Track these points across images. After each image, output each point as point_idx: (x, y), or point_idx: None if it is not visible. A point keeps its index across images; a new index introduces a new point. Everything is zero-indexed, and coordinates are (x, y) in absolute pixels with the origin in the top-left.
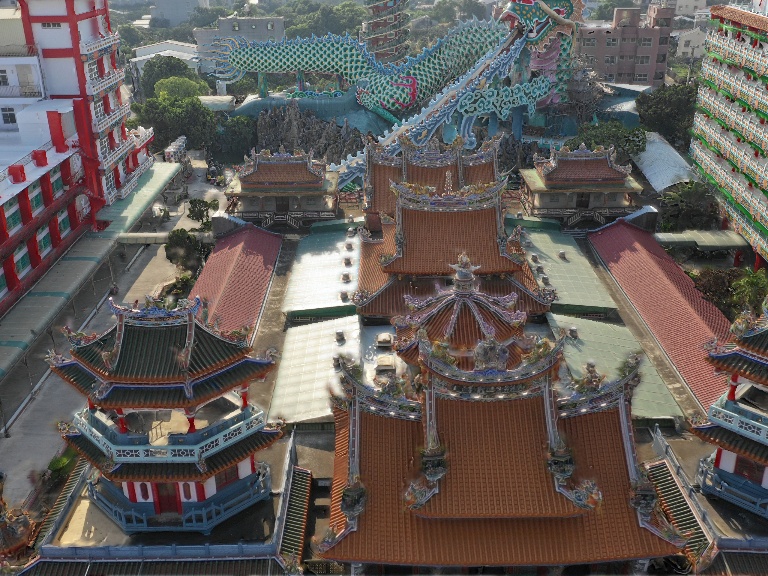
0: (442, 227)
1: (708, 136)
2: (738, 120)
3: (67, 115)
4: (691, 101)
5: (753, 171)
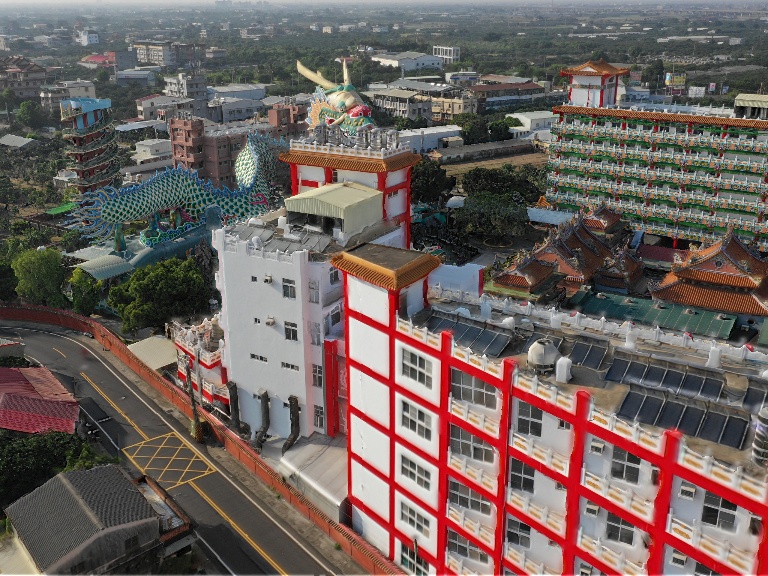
0: (734, 257)
1: (581, 185)
2: (629, 171)
3: None
4: (438, 171)
5: (666, 196)
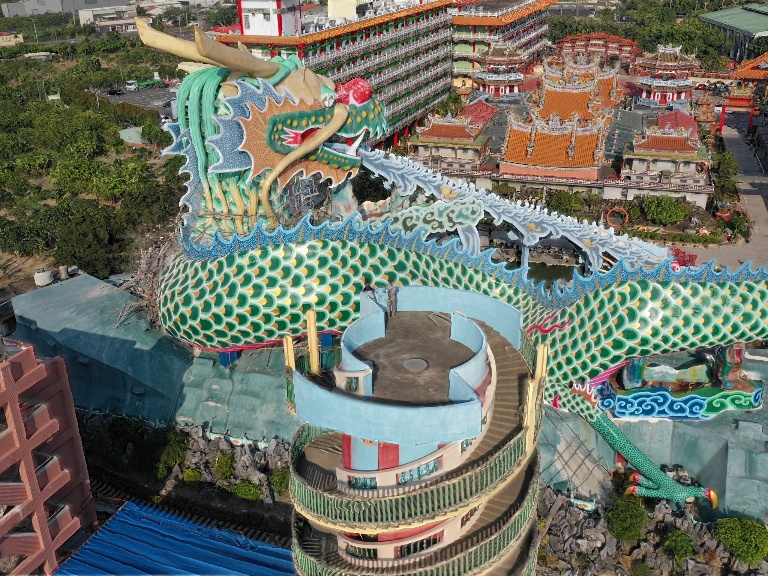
0: None
1: None
2: None
3: None
4: None
5: None
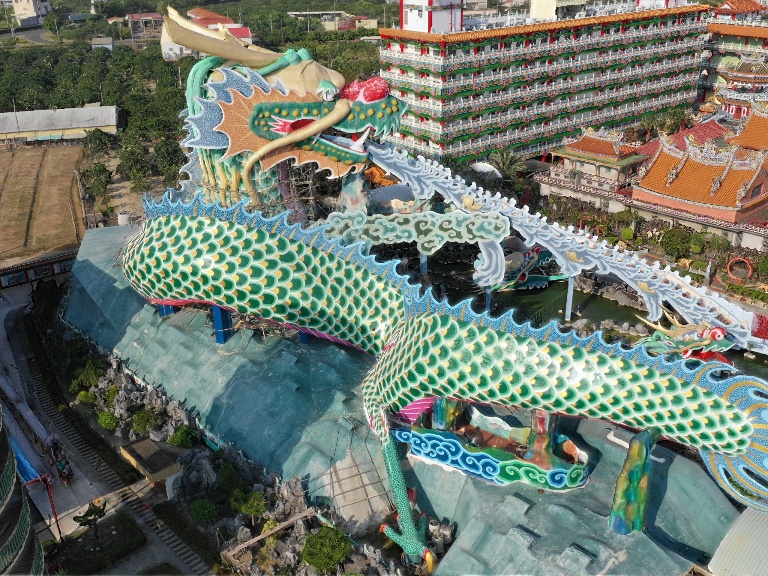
0: None
1: None
2: None
3: None
4: None
5: None
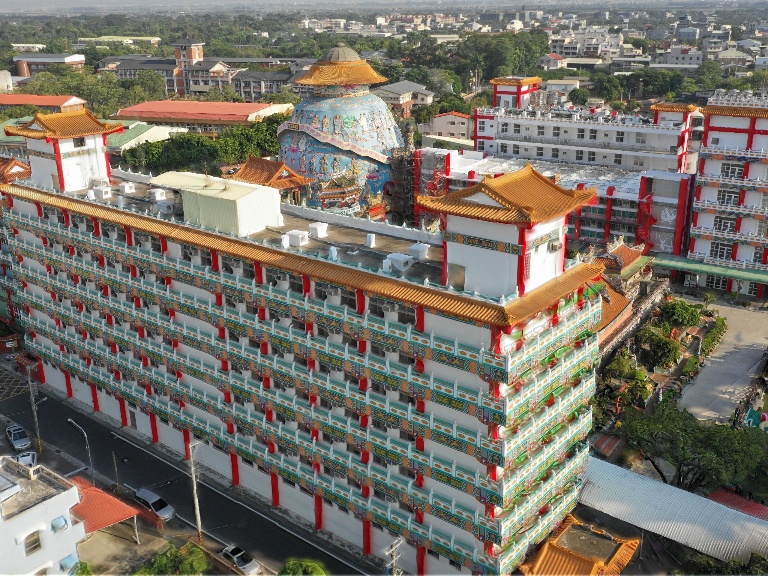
0: None
1: None
2: None
3: (670, 184)
4: None
5: None
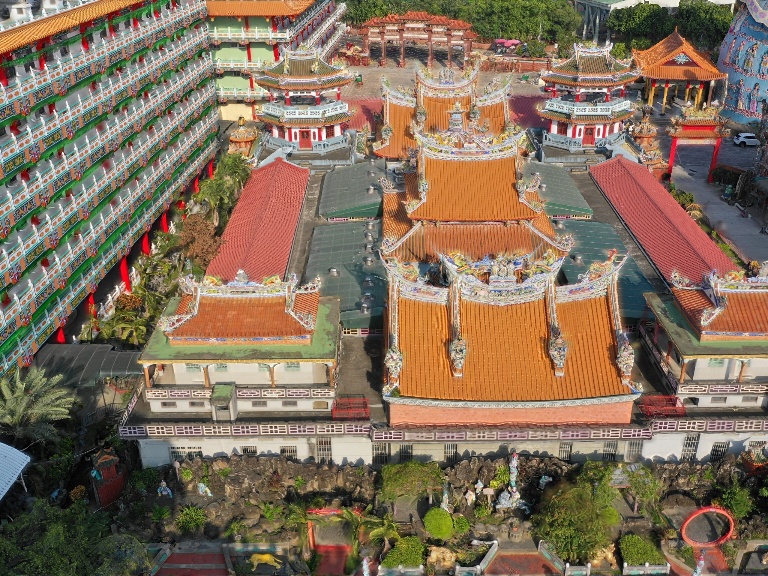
0: None
1: None
2: None
3: None
4: None
5: None
